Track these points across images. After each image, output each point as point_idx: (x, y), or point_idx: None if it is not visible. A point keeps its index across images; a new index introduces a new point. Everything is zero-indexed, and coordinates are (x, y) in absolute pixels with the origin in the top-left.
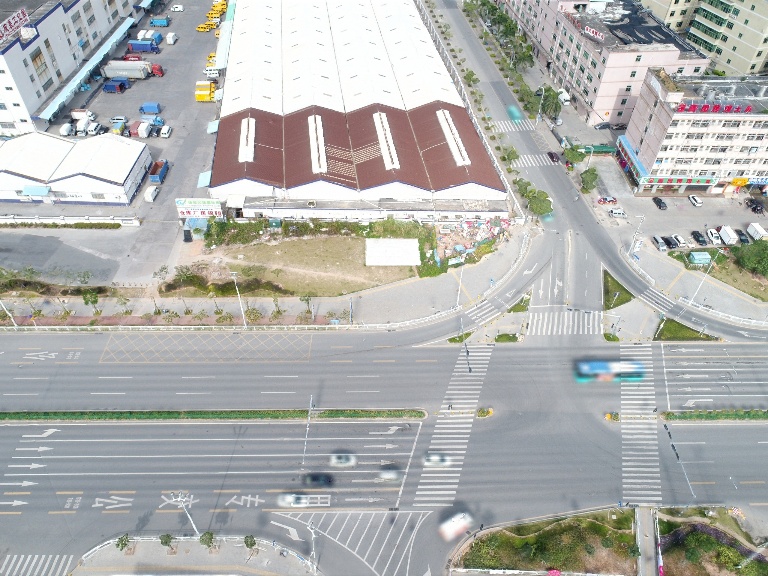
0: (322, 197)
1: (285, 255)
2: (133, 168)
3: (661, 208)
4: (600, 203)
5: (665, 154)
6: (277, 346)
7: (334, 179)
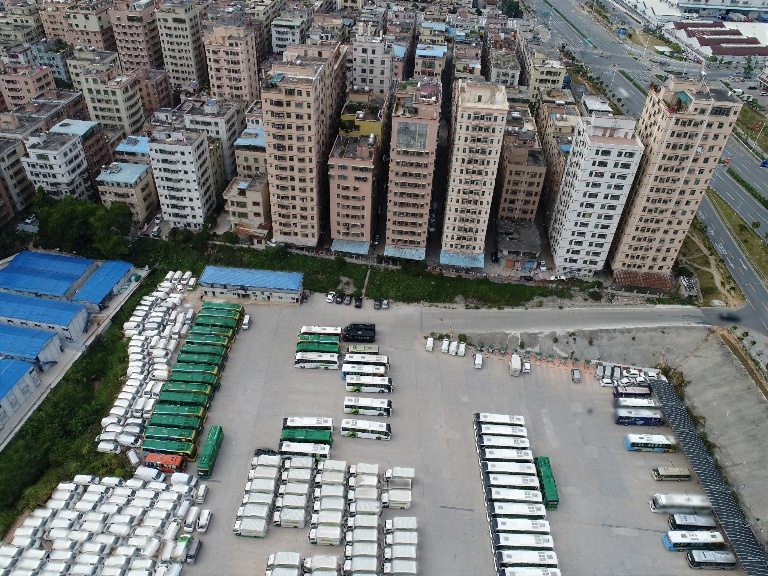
0: None
1: None
2: (666, 16)
3: None
4: (737, 78)
5: (767, 64)
6: (608, 38)
7: None
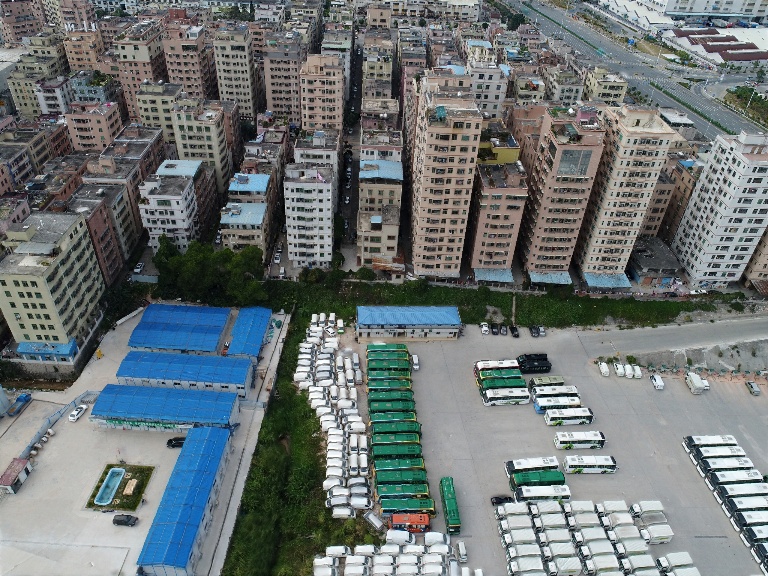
0: (683, 45)
1: (650, 45)
2: (660, 24)
3: (765, 91)
4: None
5: None
6: None
7: (690, 39)
